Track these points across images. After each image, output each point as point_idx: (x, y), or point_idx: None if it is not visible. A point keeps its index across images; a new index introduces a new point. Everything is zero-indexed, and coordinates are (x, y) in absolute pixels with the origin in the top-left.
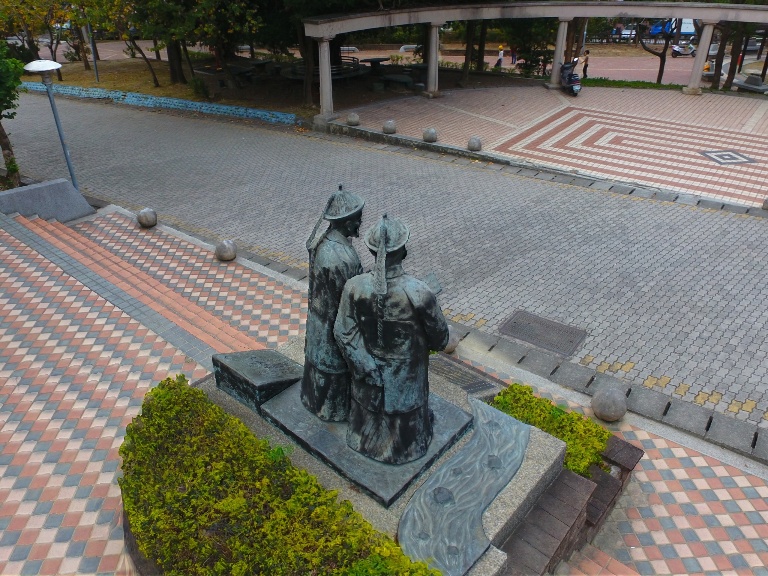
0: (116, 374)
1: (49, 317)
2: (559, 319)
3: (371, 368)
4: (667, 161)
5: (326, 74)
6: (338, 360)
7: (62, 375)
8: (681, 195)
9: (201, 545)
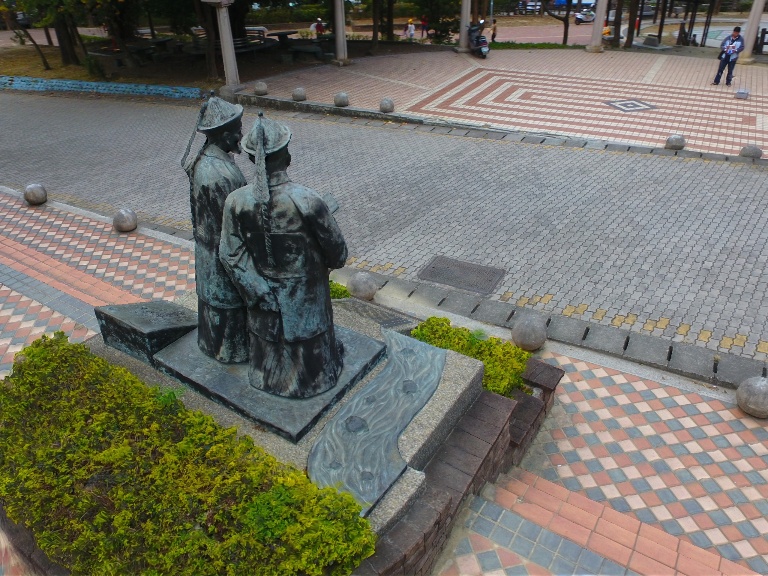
0: None
1: None
2: (477, 261)
3: (264, 291)
4: (575, 112)
5: (228, 42)
6: (232, 293)
7: None
8: (589, 141)
9: (77, 500)
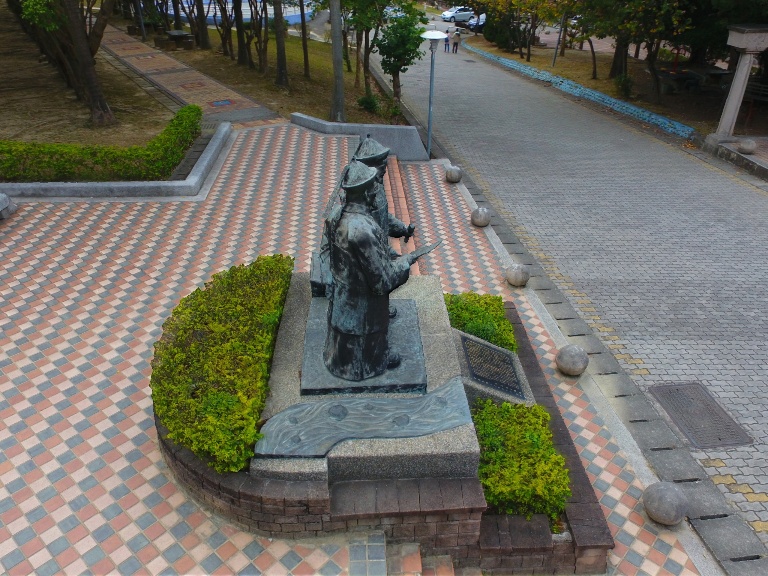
0: (302, 255)
1: (309, 208)
2: (736, 413)
3: (327, 282)
4: None
5: (737, 90)
6: None
7: (278, 242)
8: None
9: None
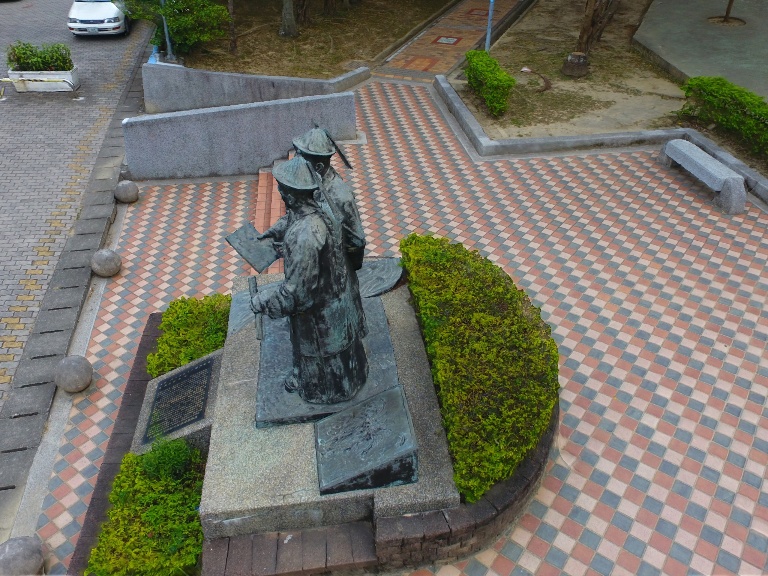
0: None
1: None
2: None
3: None
4: None
5: None
6: None
7: None
8: None
9: (515, 310)
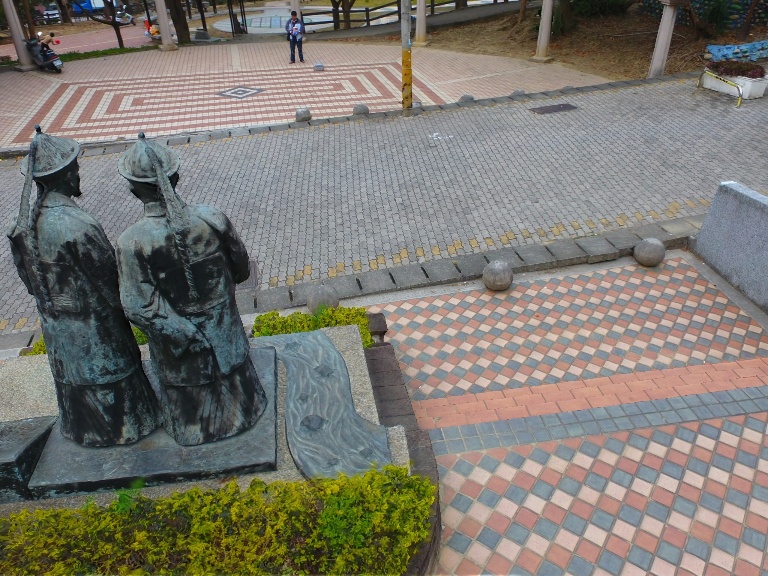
0: None
1: None
2: None
3: (193, 331)
4: (197, 107)
5: None
6: (123, 359)
7: None
8: (232, 130)
9: None
